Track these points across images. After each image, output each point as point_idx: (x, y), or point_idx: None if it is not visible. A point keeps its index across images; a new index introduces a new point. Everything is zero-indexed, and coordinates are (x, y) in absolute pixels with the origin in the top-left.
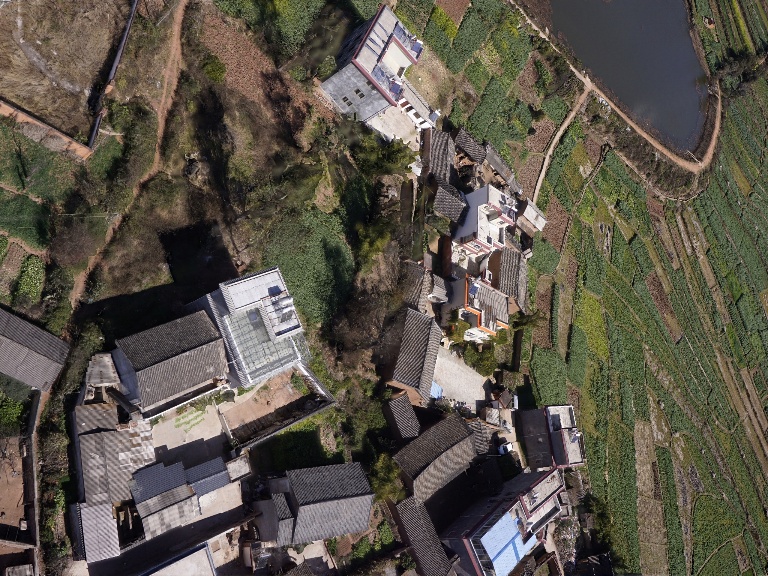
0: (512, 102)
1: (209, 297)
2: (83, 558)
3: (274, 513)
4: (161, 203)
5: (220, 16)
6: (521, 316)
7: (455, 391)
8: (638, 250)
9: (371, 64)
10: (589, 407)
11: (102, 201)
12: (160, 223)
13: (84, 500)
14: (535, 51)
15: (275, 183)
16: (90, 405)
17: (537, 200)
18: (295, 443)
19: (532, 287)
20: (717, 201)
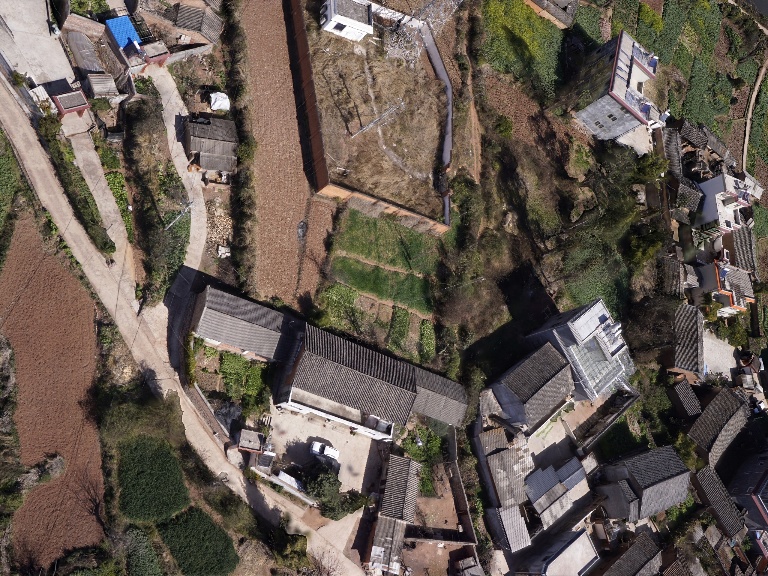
0: (713, 76)
1: (555, 332)
2: (506, 549)
3: (621, 496)
4: (494, 256)
5: (495, 75)
6: (754, 284)
7: (713, 364)
8: None
9: (623, 91)
10: None
11: (460, 266)
12: (495, 272)
13: (500, 505)
14: (724, 18)
15: (560, 214)
16: (488, 432)
17: (746, 166)
18: (614, 434)
19: None
20: None
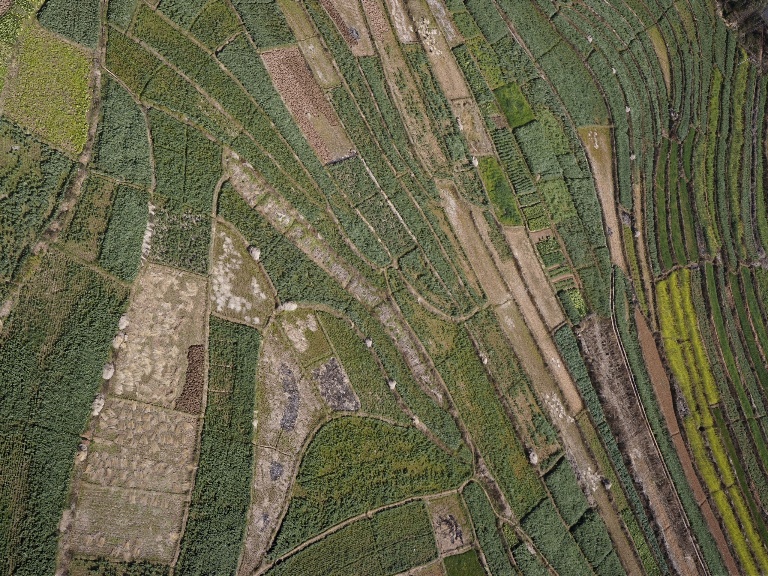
0: None
1: None
2: None
3: None
4: None
5: None
6: None
7: None
8: (252, 6)
9: None
10: None
11: None
12: None
13: None
14: None
15: None
16: None
17: None
18: None
19: None
20: None
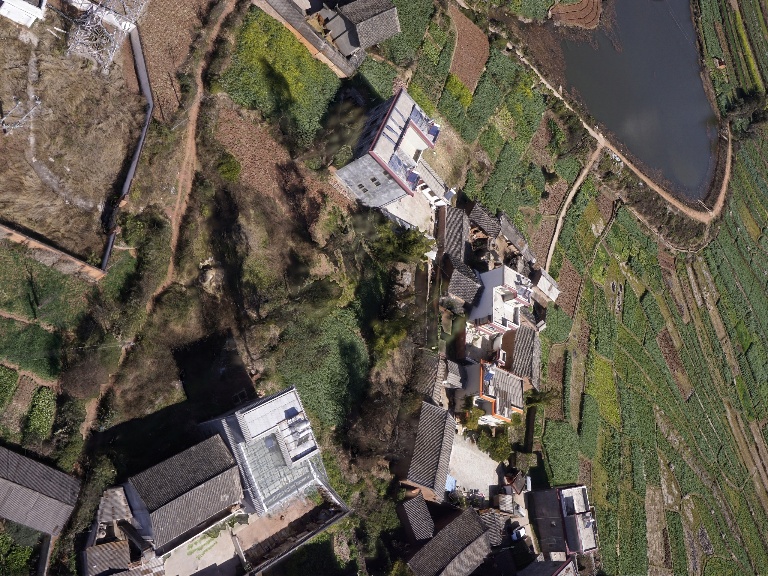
0: (526, 166)
1: (224, 423)
2: None
3: None
4: (175, 318)
5: (235, 109)
6: (534, 393)
7: (468, 479)
8: (649, 307)
9: (388, 153)
10: (601, 478)
11: (115, 324)
12: (173, 338)
13: None
14: (548, 110)
15: (290, 281)
16: (101, 545)
17: (550, 265)
18: (308, 556)
19: (545, 358)
20: (727, 249)
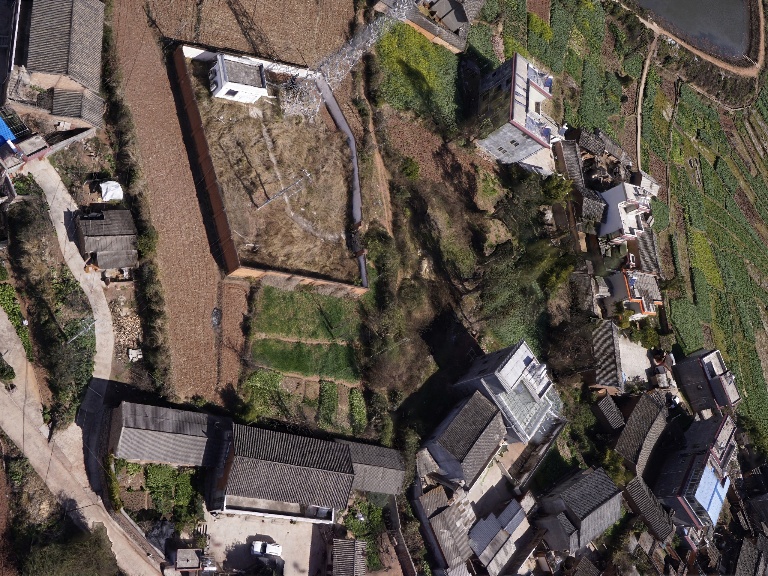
0: (603, 77)
1: (483, 381)
2: None
3: (560, 529)
4: (415, 308)
5: (395, 114)
6: (659, 282)
7: (630, 369)
8: (723, 172)
9: (523, 117)
10: (719, 337)
11: (383, 326)
12: (418, 324)
13: (447, 566)
14: (607, 15)
15: (474, 249)
16: (427, 493)
17: (640, 162)
18: (546, 463)
19: None
20: None
